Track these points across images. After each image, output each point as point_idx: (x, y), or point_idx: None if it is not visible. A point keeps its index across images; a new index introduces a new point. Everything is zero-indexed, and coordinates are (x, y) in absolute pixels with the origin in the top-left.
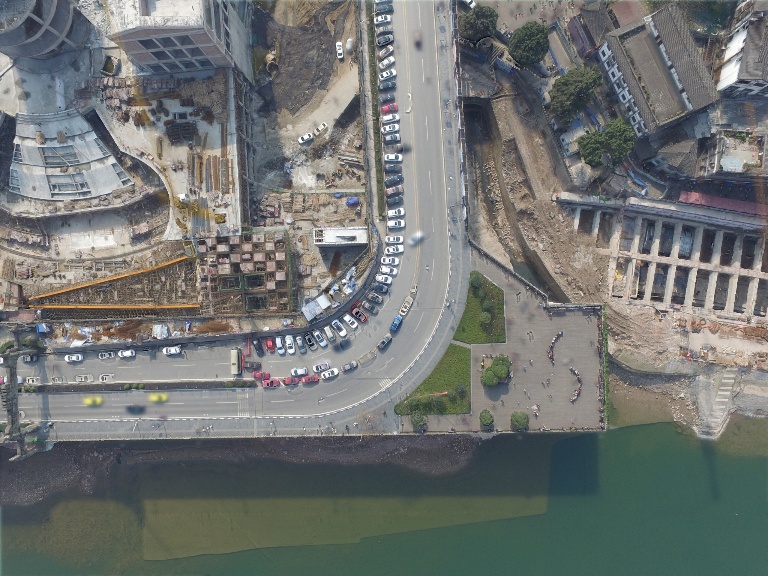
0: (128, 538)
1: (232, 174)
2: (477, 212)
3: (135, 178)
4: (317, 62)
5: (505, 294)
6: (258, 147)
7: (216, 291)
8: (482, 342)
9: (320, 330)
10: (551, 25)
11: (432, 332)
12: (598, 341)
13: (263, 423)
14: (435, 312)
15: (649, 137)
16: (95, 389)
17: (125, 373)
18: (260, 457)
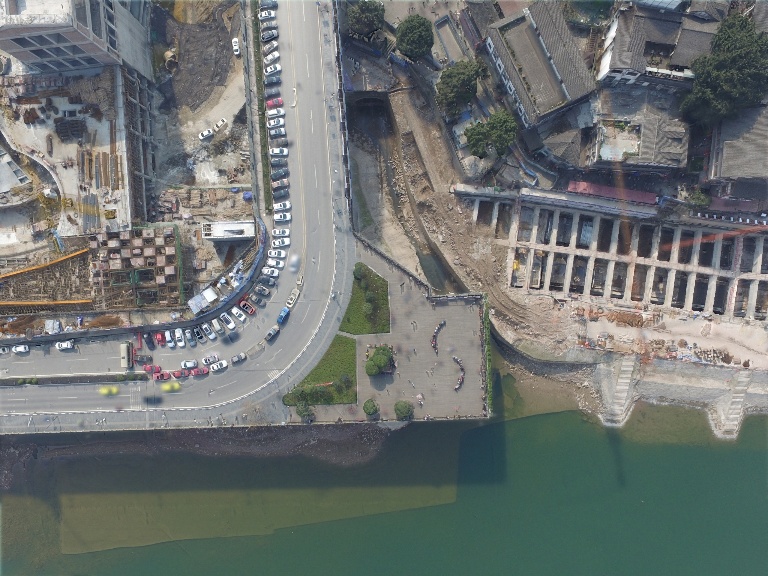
0: (46, 532)
1: (121, 170)
2: (381, 205)
3: (32, 176)
4: (215, 59)
5: (389, 285)
6: (160, 144)
7: (108, 286)
8: (367, 332)
9: (209, 323)
10: (443, 18)
11: (319, 323)
12: (480, 330)
13: (155, 415)
14: (321, 304)
15: (540, 128)
16: None
17: (19, 368)
18: (174, 451)
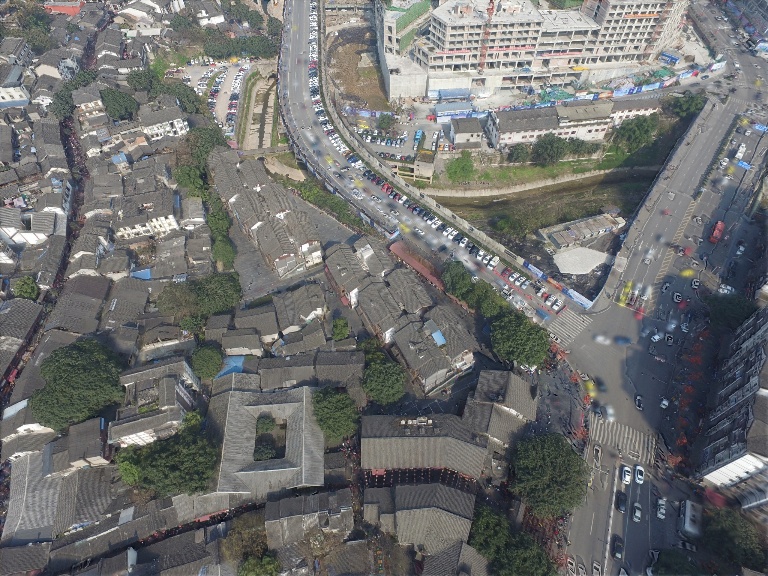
0: None
1: None
2: None
3: None
4: None
5: None
6: None
7: None
8: None
9: None
10: None
11: None
12: None
13: None
14: None
15: None
16: None
17: None
18: None
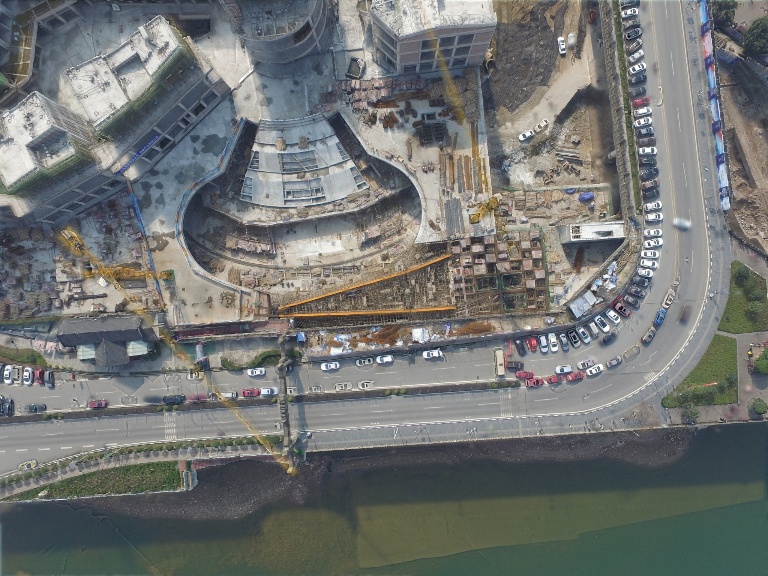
0: (342, 547)
1: (485, 173)
2: None
3: None
4: (536, 58)
5: (767, 282)
6: None
7: (472, 292)
8: (747, 331)
9: (582, 327)
10: None
11: (695, 324)
12: None
13: (528, 423)
14: (697, 303)
15: None
16: (355, 396)
17: (384, 379)
18: (474, 458)
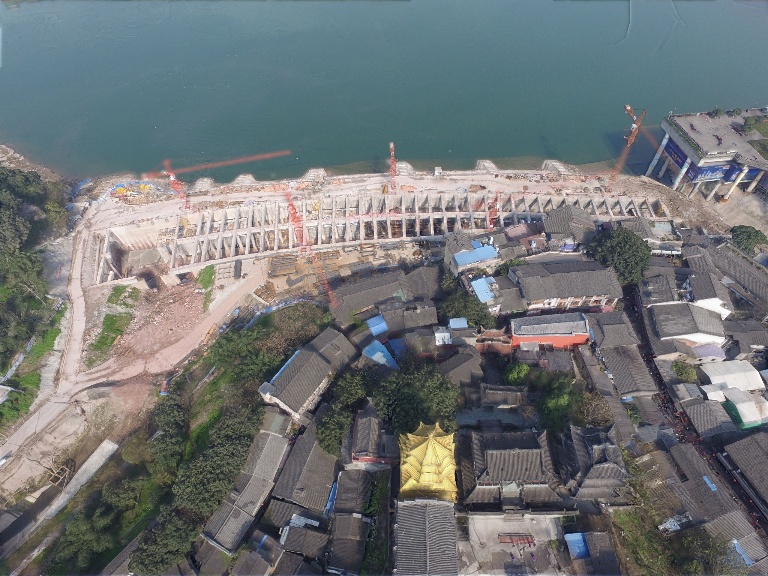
0: None
1: None
2: None
3: None
4: None
5: None
6: None
7: None
8: (760, 140)
9: None
10: None
11: None
12: None
13: None
14: None
15: None
16: None
17: None
18: None
